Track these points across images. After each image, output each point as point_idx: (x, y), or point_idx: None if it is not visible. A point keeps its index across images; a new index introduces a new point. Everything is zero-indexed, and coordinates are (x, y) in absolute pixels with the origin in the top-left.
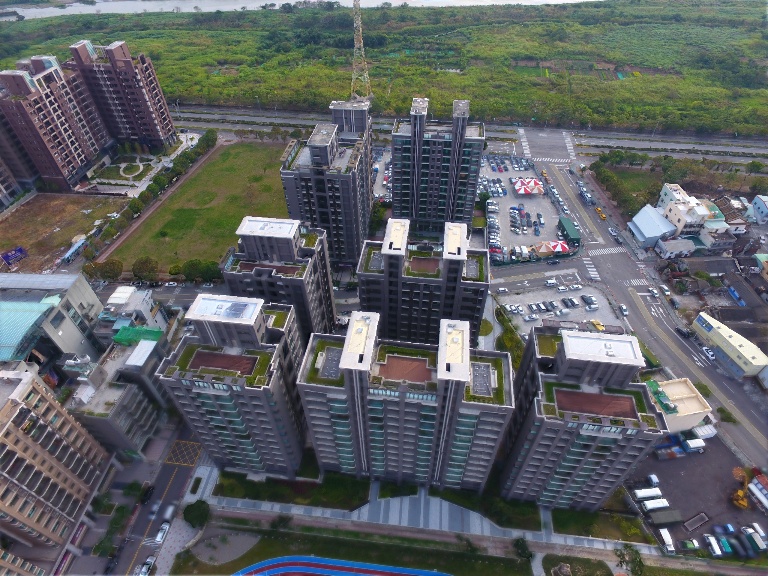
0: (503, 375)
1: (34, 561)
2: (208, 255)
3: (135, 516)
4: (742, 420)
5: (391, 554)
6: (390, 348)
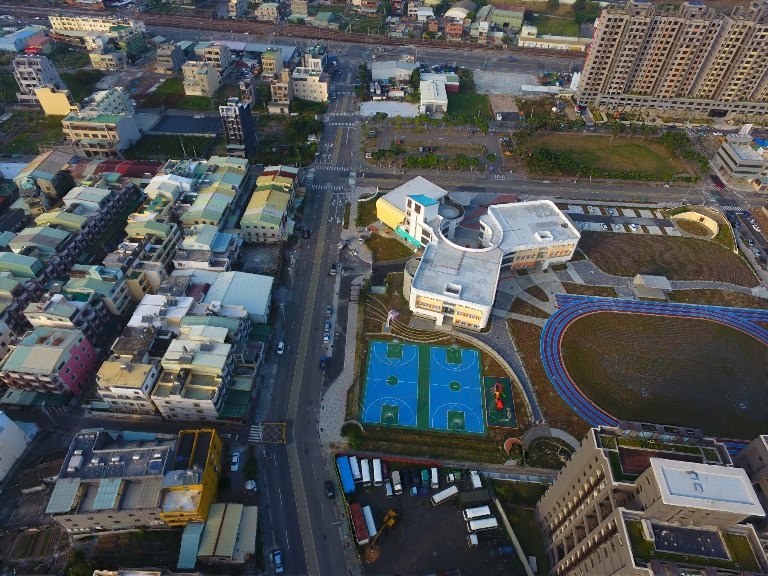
0: None
1: None
2: None
3: None
4: None
5: None
6: None
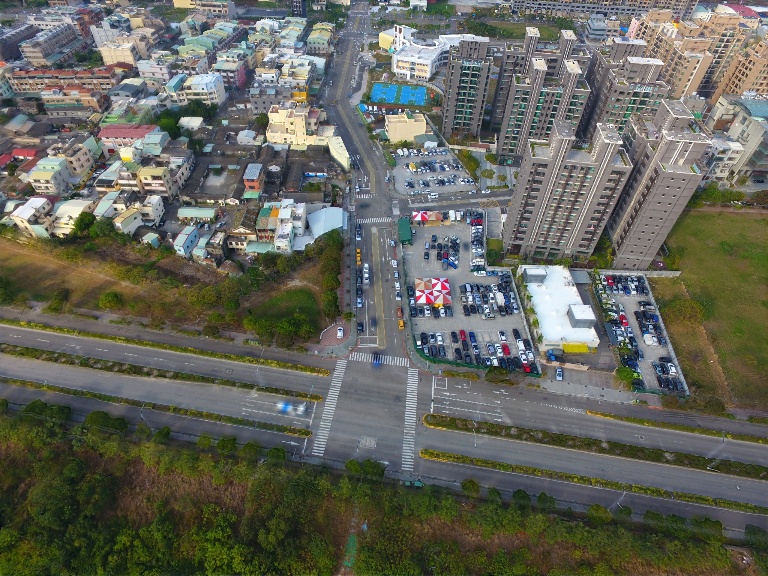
0: None
1: None
2: (737, 226)
3: None
4: (355, 138)
5: None
6: None
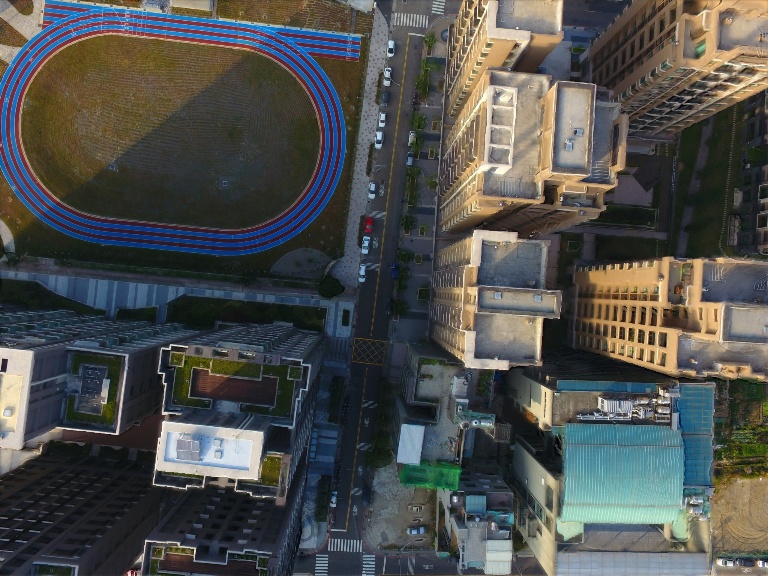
0: None
1: (453, 237)
2: None
3: (396, 288)
4: None
5: (145, 258)
6: None
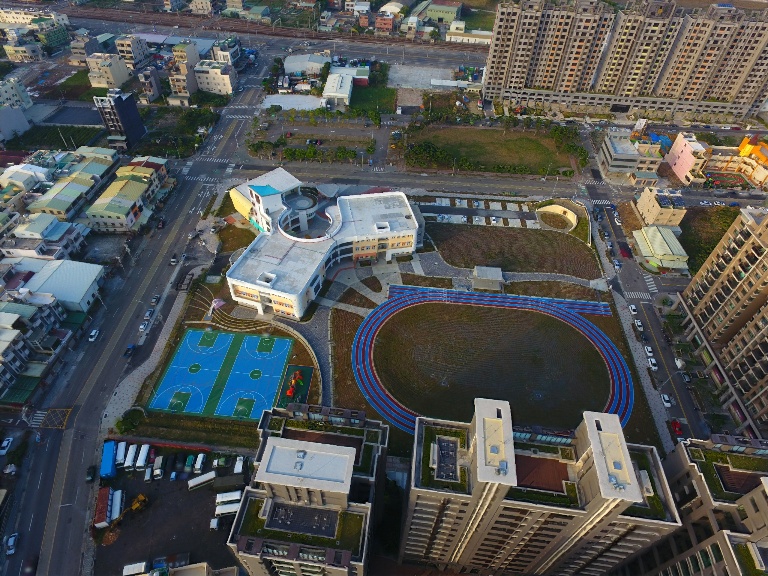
0: (422, 463)
1: None
2: None
3: None
4: None
5: None
6: (565, 501)
